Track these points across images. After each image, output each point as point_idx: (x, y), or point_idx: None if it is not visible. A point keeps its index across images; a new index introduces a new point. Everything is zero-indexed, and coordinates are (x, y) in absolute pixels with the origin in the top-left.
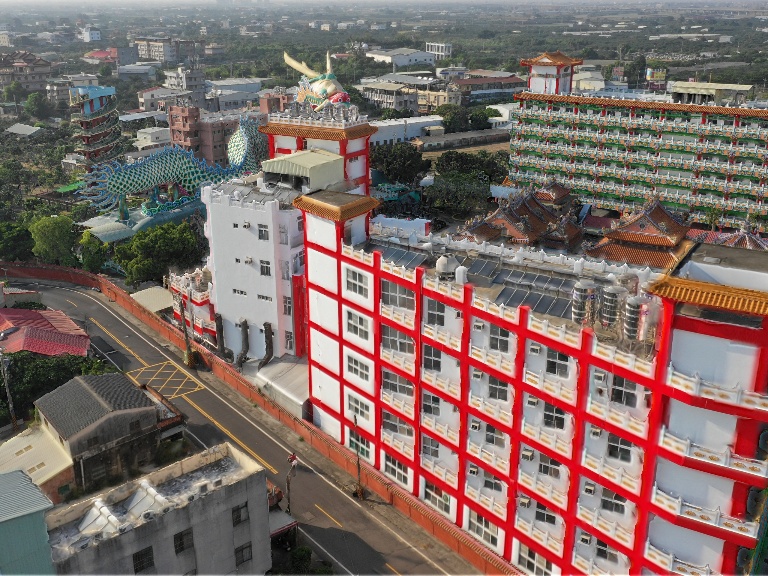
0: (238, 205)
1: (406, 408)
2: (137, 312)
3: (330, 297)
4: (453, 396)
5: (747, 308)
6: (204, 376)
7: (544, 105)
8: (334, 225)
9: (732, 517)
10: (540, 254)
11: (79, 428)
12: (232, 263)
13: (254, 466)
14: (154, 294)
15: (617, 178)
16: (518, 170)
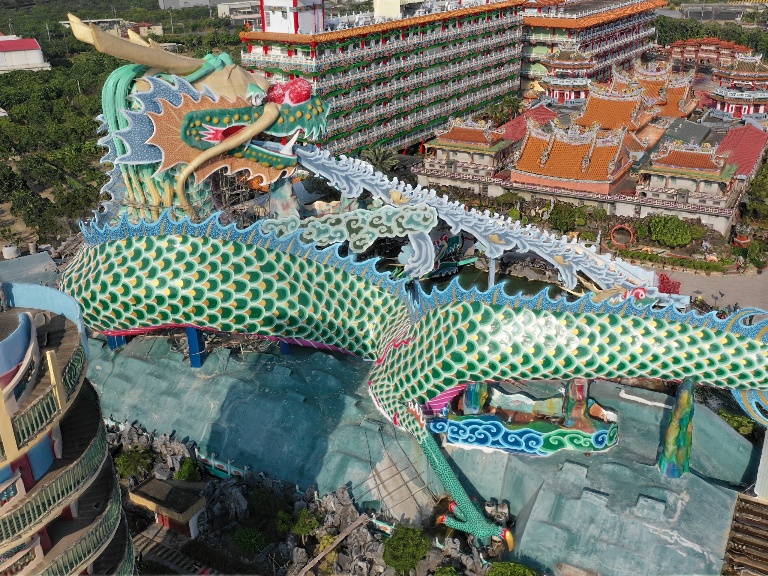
0: None
1: None
2: None
3: None
4: None
5: None
6: None
7: None
8: None
9: None
10: None
11: None
12: None
13: None
14: None
15: None
16: None
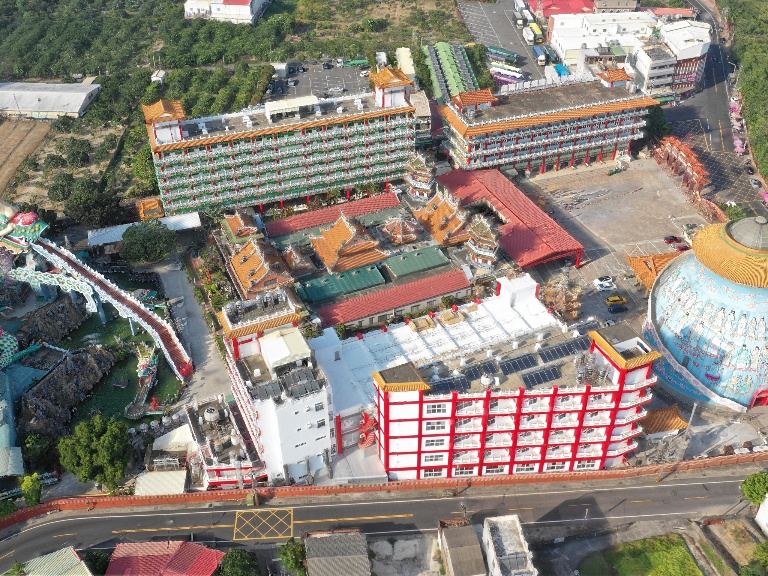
0: (299, 402)
1: (474, 445)
2: (142, 502)
3: (412, 421)
4: (510, 430)
5: (650, 360)
6: (276, 503)
7: (180, 150)
8: (418, 390)
9: (640, 414)
10: None
11: (368, 575)
12: (295, 433)
13: (511, 517)
14: (152, 482)
15: (254, 185)
16: (172, 203)
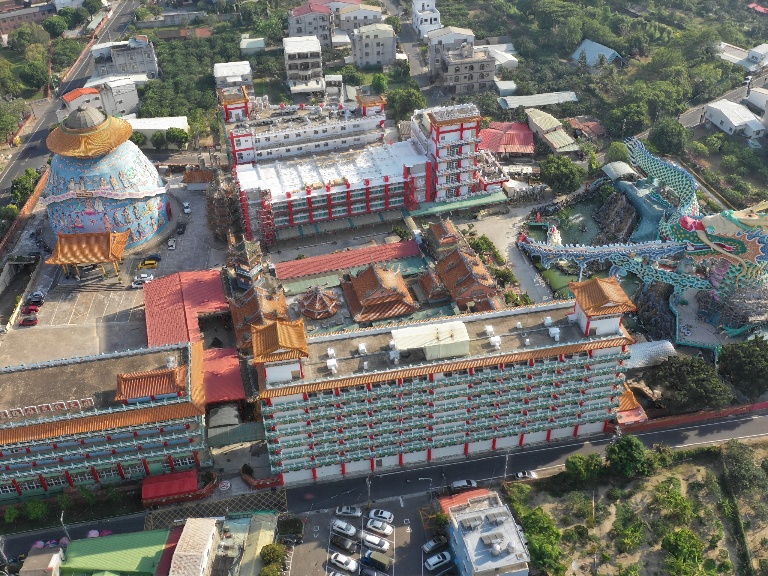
0: None
1: None
2: None
3: None
4: None
5: None
6: None
7: None
8: None
9: None
10: (308, 127)
11: None
12: None
13: None
14: (523, 170)
15: None
16: None
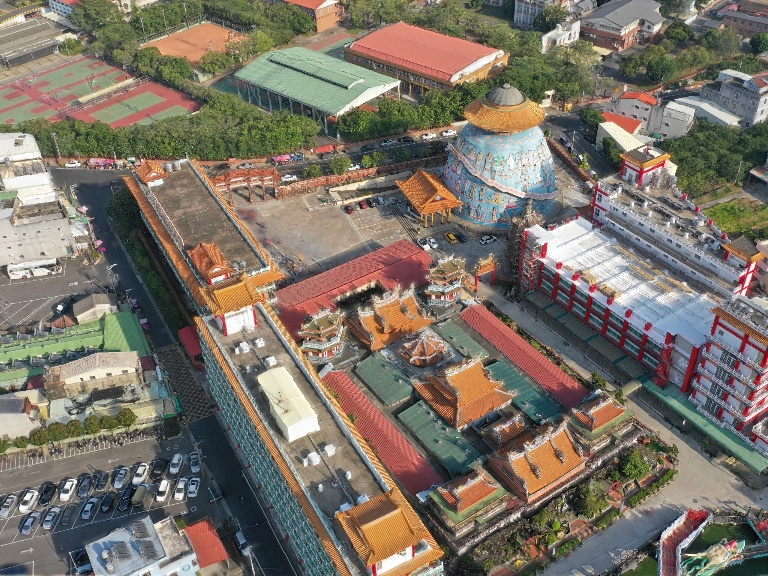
0: None
1: None
2: None
3: None
4: None
5: None
6: None
7: None
8: None
9: None
10: None
11: None
12: None
13: None
14: None
15: None
16: None
